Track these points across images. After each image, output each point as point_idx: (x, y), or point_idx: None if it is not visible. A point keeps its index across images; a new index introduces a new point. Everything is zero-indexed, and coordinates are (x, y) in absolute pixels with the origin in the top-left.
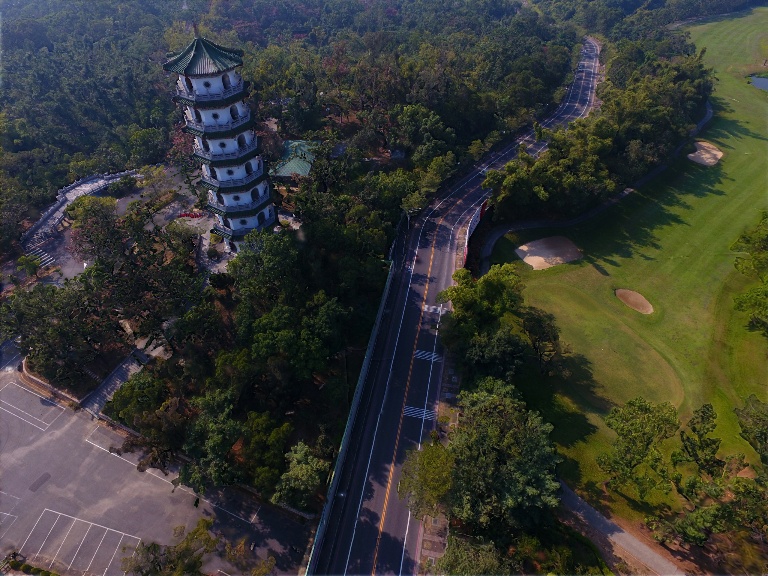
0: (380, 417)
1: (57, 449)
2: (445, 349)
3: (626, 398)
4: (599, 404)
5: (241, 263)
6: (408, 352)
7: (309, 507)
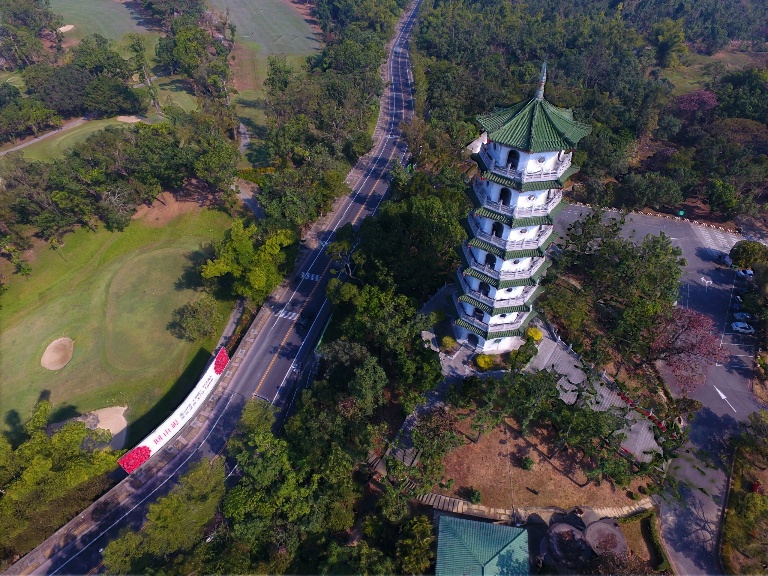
0: (356, 244)
1: (566, 233)
2: (293, 280)
3: (174, 259)
4: (197, 256)
5: (462, 216)
6: (325, 280)
7: (400, 201)
